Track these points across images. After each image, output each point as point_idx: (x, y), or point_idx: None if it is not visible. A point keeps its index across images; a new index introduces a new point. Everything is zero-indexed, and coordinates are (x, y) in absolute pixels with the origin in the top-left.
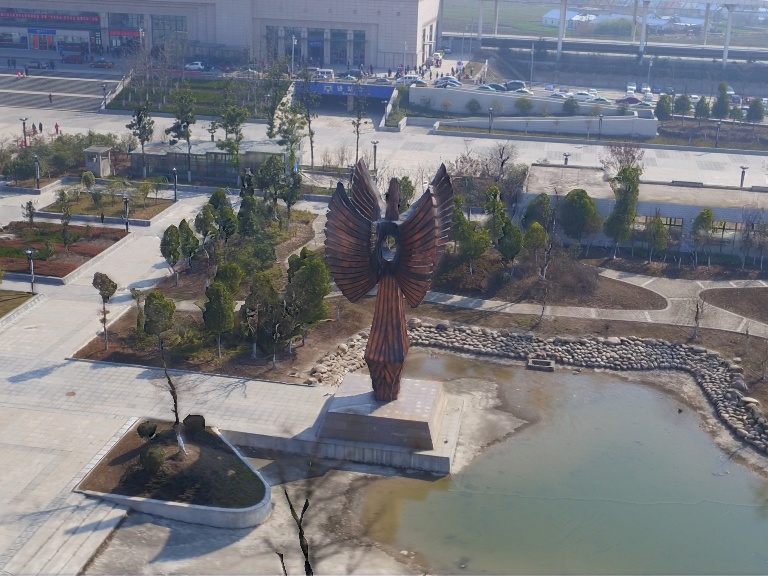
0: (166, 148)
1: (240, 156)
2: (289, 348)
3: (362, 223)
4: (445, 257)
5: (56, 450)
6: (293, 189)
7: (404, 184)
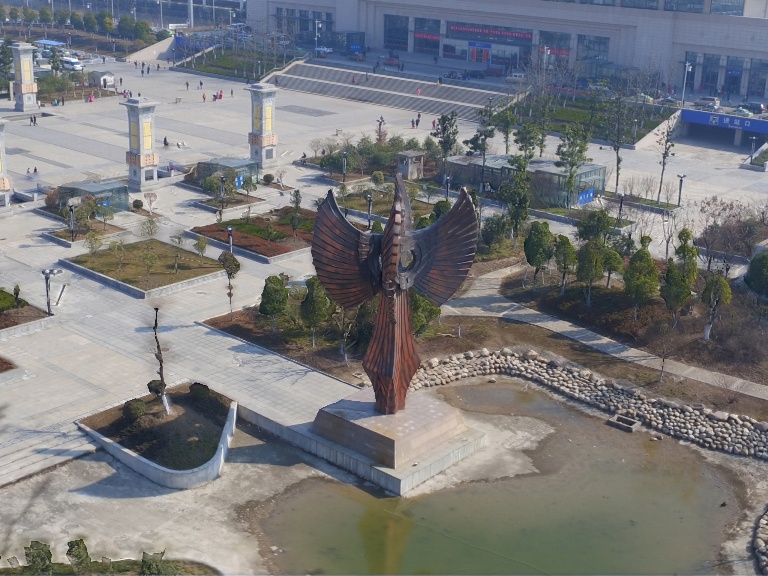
0: (475, 159)
1: (528, 174)
2: None
3: (350, 232)
4: (622, 298)
5: (101, 389)
6: (518, 208)
7: (598, 216)
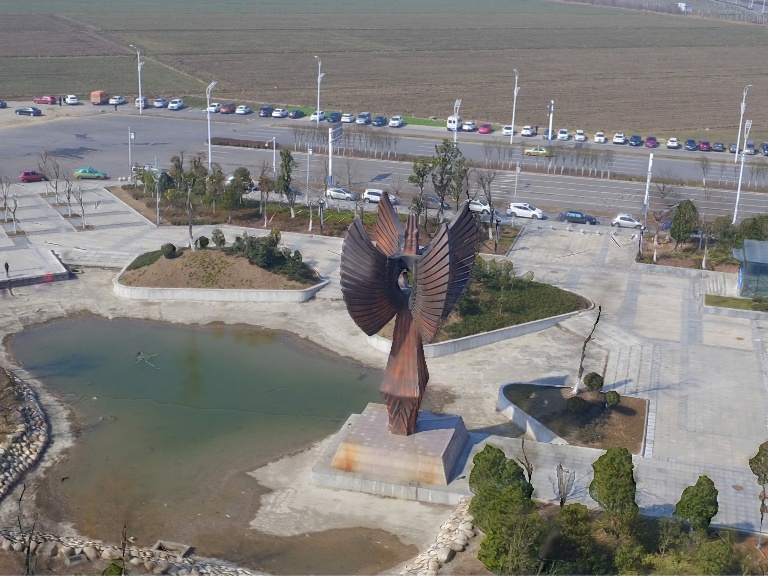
0: None
1: None
2: None
3: None
4: None
5: (693, 430)
6: None
7: None
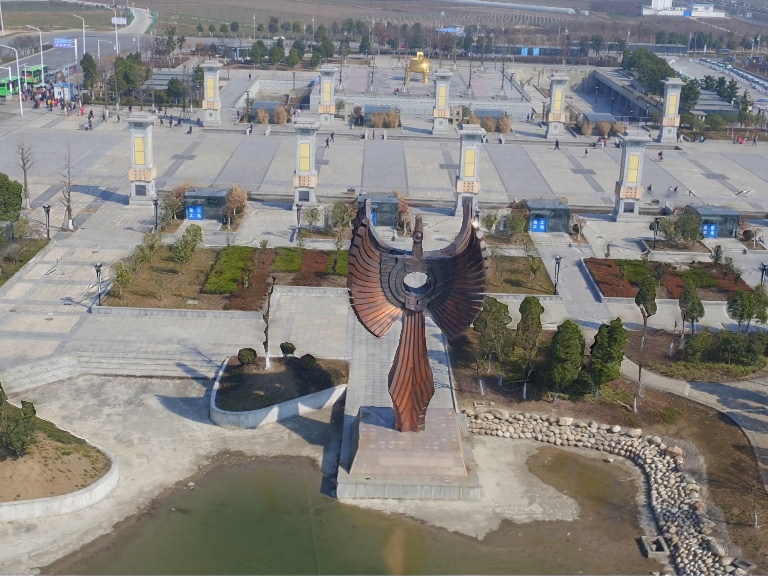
0: None
1: None
2: (523, 392)
3: (372, 241)
4: None
5: None
6: None
7: None
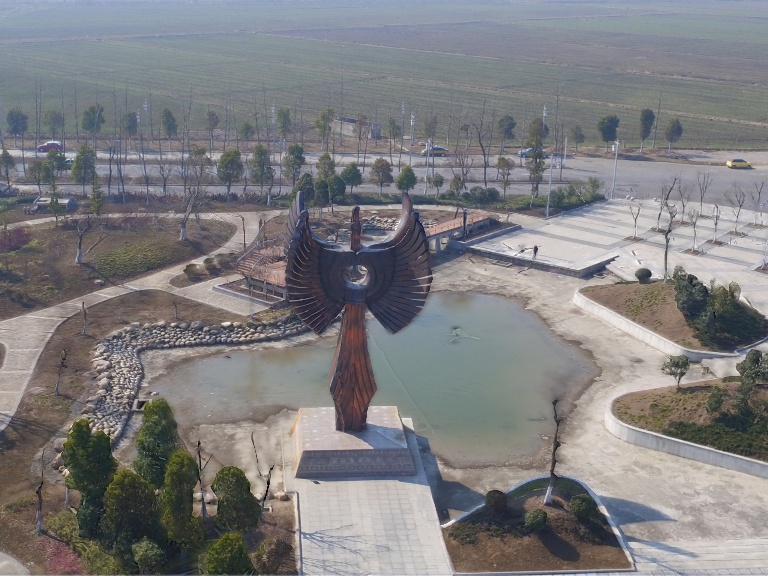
0: None
1: None
2: (206, 513)
3: None
4: None
5: None
6: None
7: None
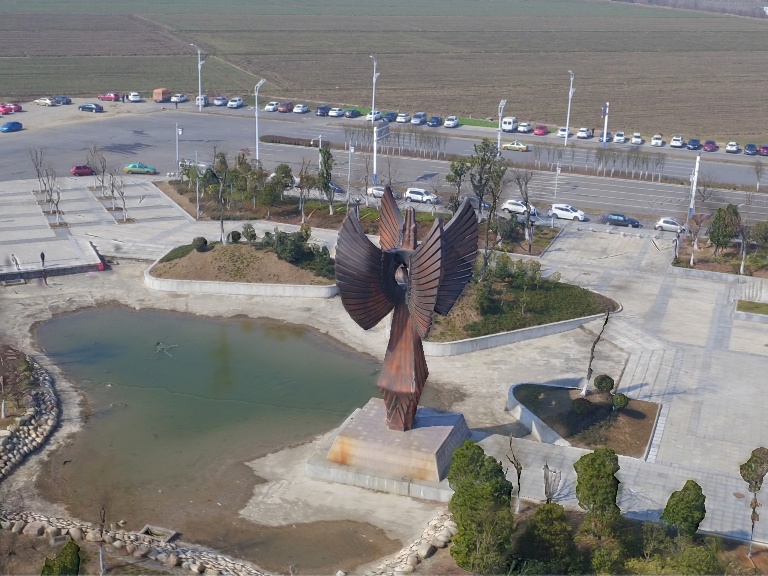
0: None
1: None
2: None
3: None
4: None
5: (702, 436)
6: None
7: None
